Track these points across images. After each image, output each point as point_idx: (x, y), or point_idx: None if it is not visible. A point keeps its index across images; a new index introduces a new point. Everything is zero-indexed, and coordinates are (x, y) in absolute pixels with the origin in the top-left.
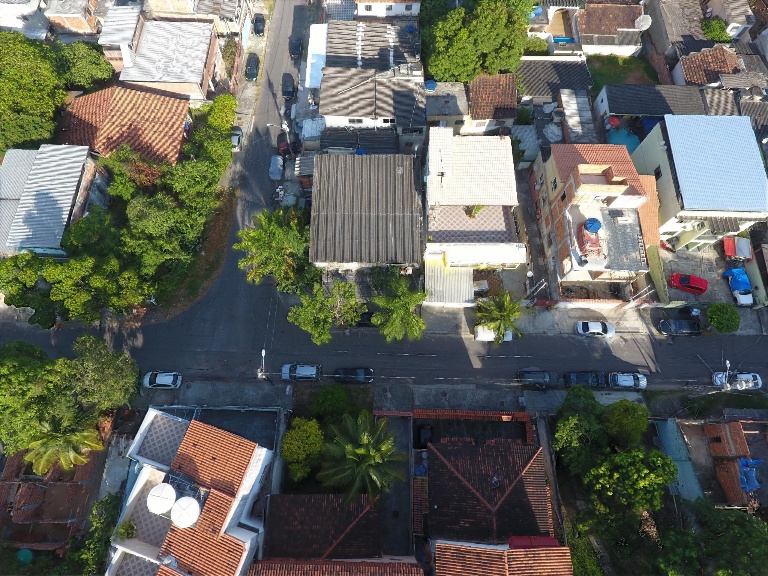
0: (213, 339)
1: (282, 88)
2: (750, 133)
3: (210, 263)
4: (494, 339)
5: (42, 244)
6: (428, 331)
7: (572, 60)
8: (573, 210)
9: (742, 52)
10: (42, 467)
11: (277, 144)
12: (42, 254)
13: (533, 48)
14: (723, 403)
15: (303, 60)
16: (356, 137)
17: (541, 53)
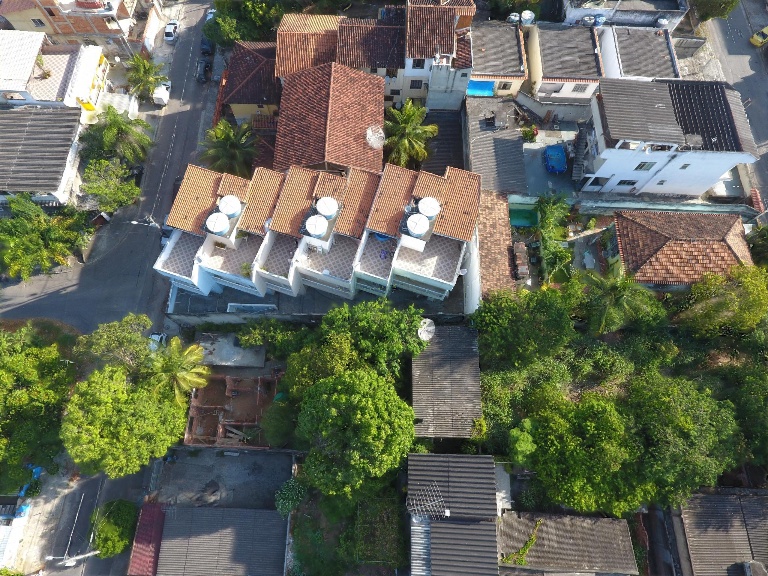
0: (125, 312)
1: None
2: None
3: (43, 330)
4: (167, 90)
5: None
6: (153, 138)
7: None
8: (64, 8)
9: None
10: (199, 380)
11: None
12: None
13: None
14: None
15: None
16: None
17: None
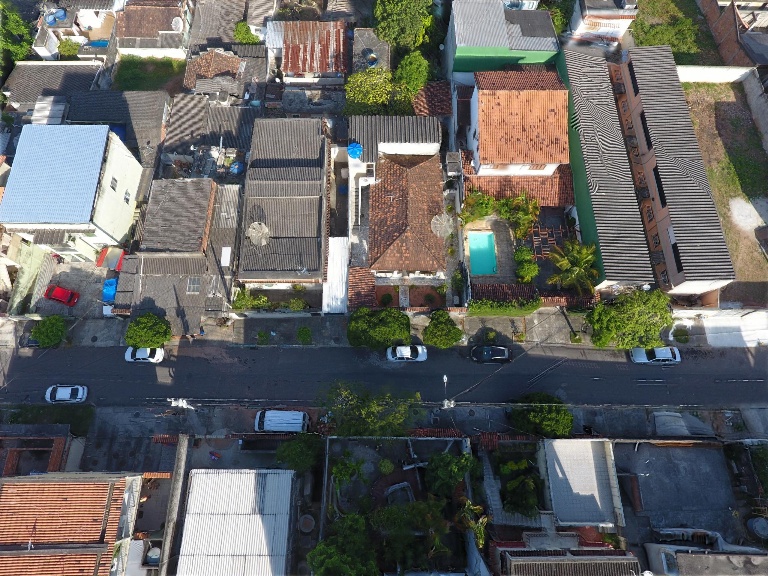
0: None
1: None
2: (101, 143)
3: None
4: None
5: None
6: None
7: (89, 65)
8: None
9: (254, 55)
10: None
11: None
12: None
13: (63, 52)
14: (48, 417)
15: None
16: None
17: (74, 57)
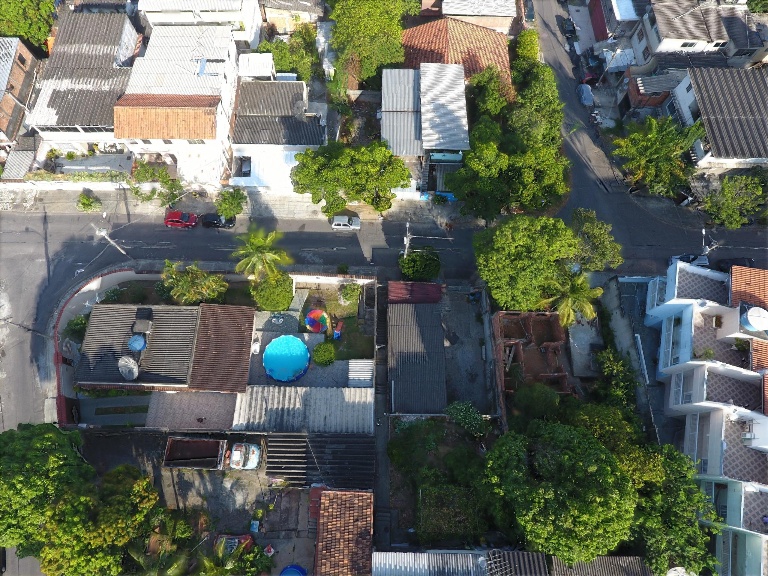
0: None
1: (561, 28)
2: None
3: None
4: None
5: (454, 147)
6: None
7: None
8: None
9: None
10: None
11: (574, 76)
12: (436, 160)
13: None
14: None
15: (569, 4)
16: (688, 60)
17: None
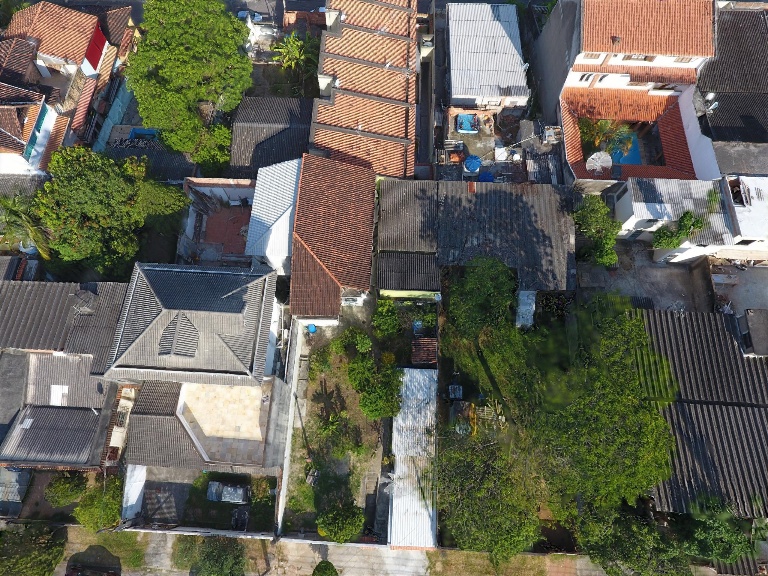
0: None
1: None
2: None
3: None
4: None
5: None
6: None
7: None
8: None
9: None
10: None
11: None
12: None
13: None
14: None
15: None
16: None
17: None
